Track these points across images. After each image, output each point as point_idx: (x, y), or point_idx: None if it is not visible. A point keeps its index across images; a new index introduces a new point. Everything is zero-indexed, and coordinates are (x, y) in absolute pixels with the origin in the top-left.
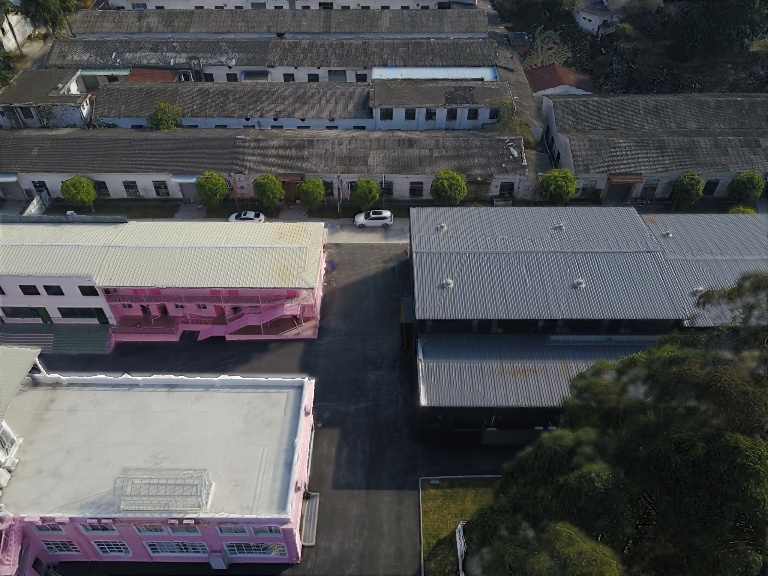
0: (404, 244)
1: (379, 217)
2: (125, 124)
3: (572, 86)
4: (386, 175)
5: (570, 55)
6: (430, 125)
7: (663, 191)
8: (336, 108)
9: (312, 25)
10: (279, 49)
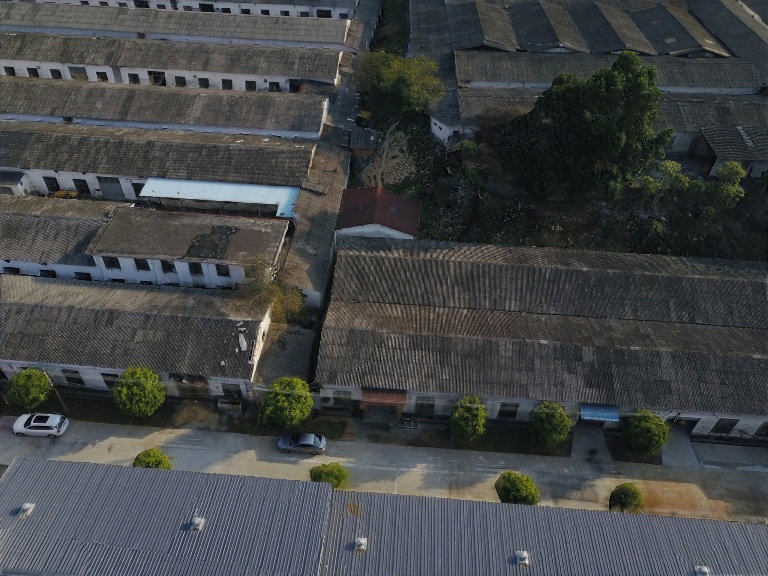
0: None
1: (41, 426)
2: None
3: (384, 225)
4: (63, 365)
5: (414, 169)
6: (172, 278)
7: (444, 409)
8: (52, 248)
9: (106, 109)
10: (41, 145)
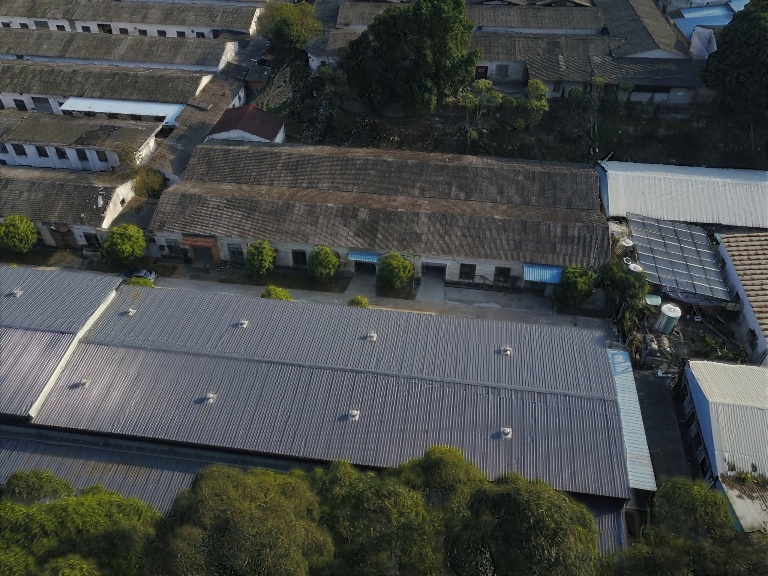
0: None
1: None
2: None
3: (245, 131)
4: None
5: (291, 95)
6: (66, 164)
7: None
8: None
9: (51, 49)
10: None
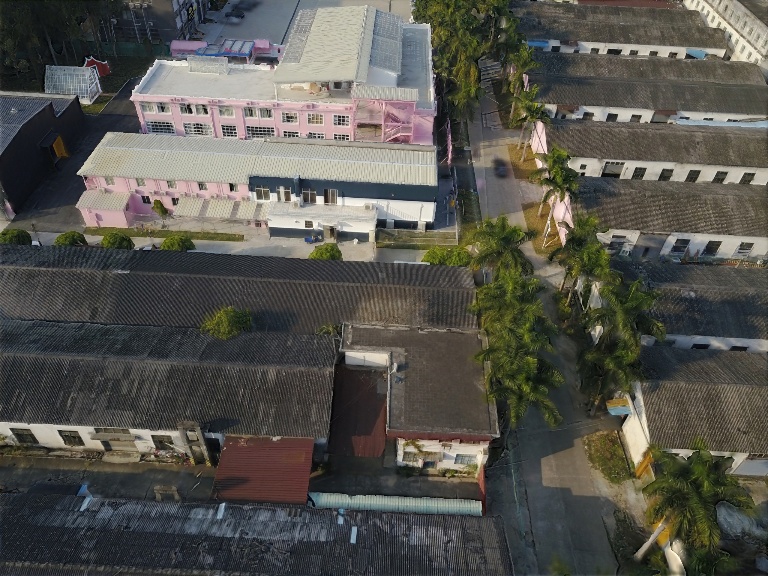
0: None
1: None
2: None
3: None
4: None
5: None
6: None
7: None
8: None
9: None
10: None
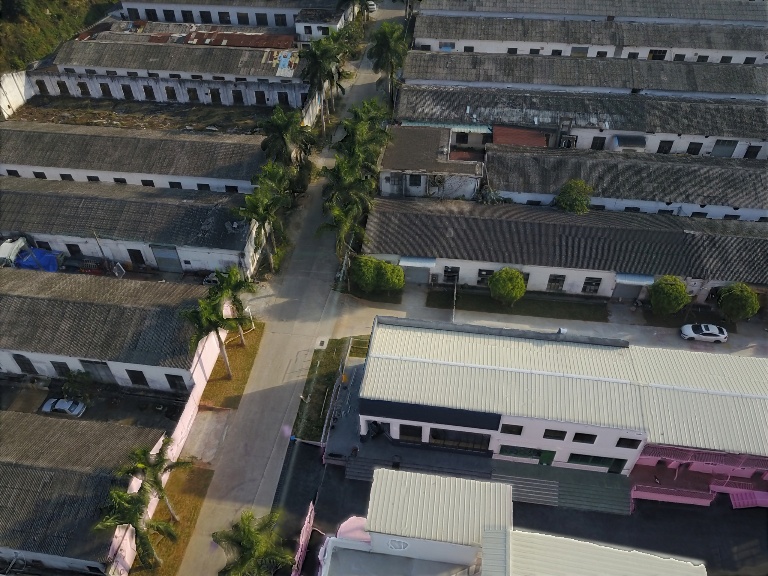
0: None
1: None
2: (520, 199)
3: None
4: None
5: None
6: None
7: None
8: None
9: (674, 81)
10: (657, 112)
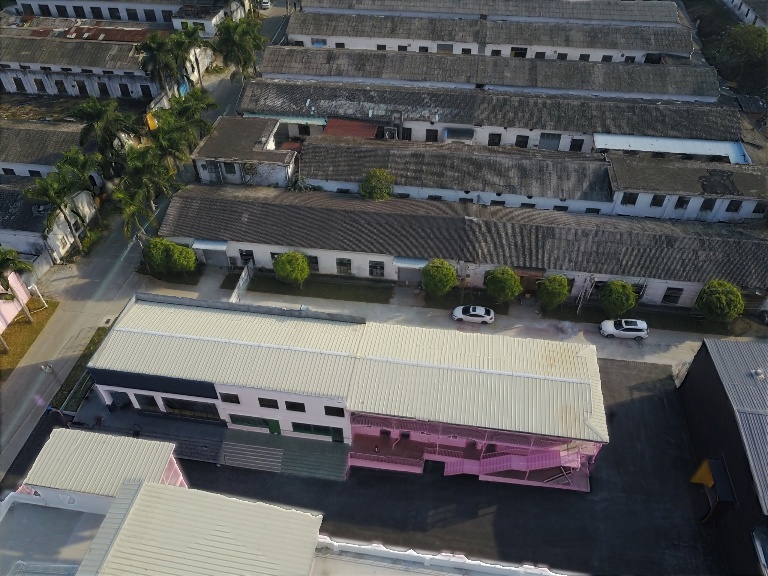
0: (666, 366)
1: (634, 329)
2: (330, 187)
3: None
4: (642, 279)
5: None
6: (678, 214)
7: None
8: (569, 186)
9: (516, 77)
10: (487, 106)
